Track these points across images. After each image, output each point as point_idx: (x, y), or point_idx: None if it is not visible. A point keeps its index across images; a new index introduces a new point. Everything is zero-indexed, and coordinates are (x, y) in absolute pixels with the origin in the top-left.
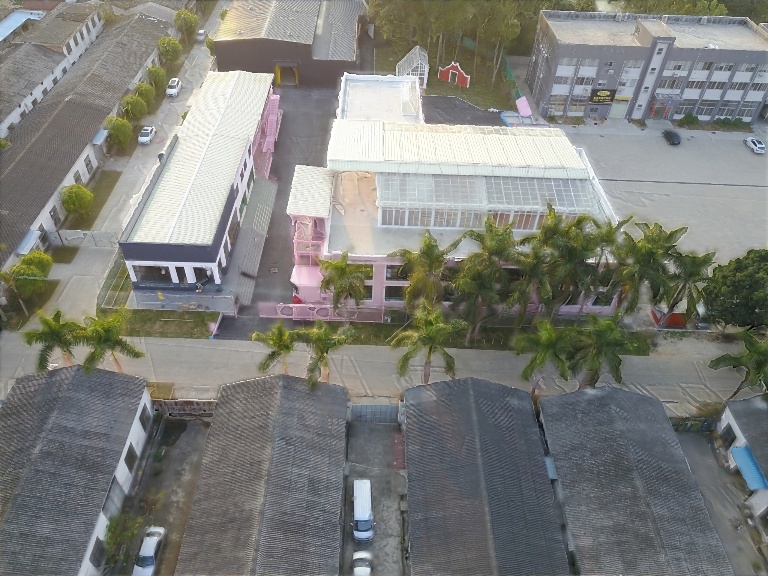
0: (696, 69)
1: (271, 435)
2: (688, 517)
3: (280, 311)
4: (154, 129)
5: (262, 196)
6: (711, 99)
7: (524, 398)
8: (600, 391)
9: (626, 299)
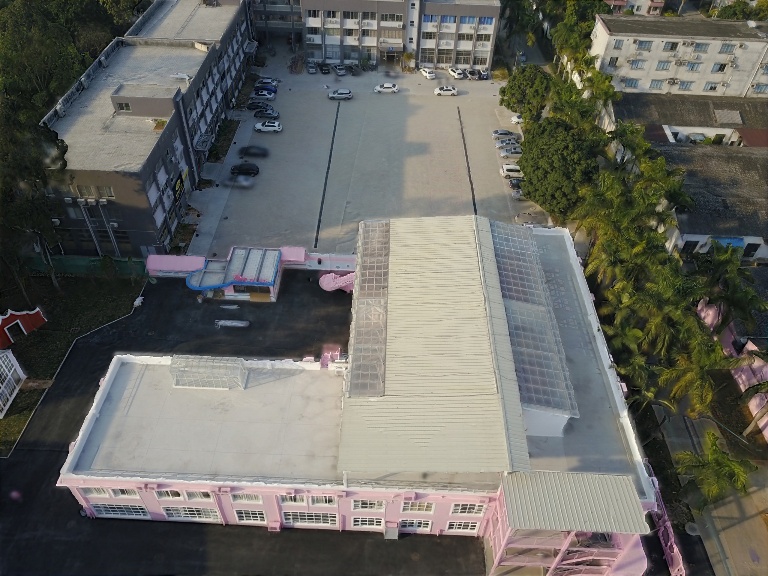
0: None
1: None
2: None
3: None
4: None
5: None
6: None
7: (759, 341)
8: None
9: None
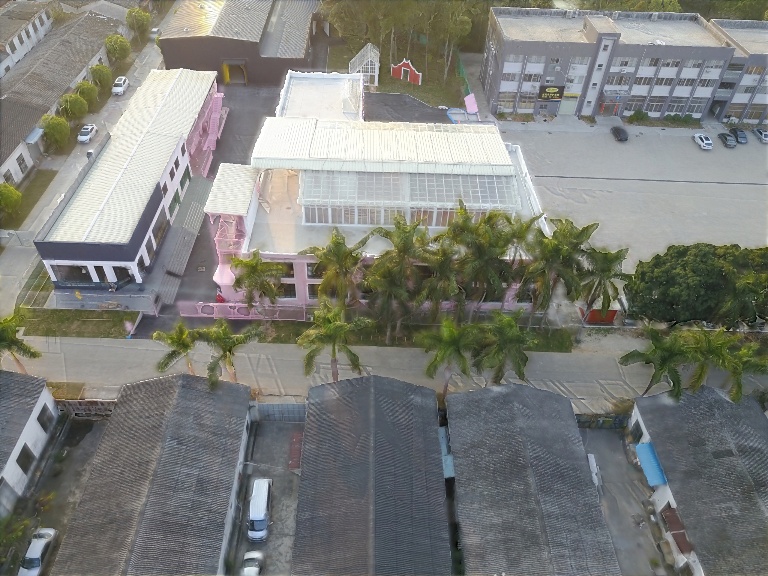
0: (643, 65)
1: (163, 435)
2: (580, 514)
3: (202, 310)
4: (95, 128)
5: (197, 194)
6: (660, 95)
7: (428, 396)
8: (505, 388)
9: (556, 296)
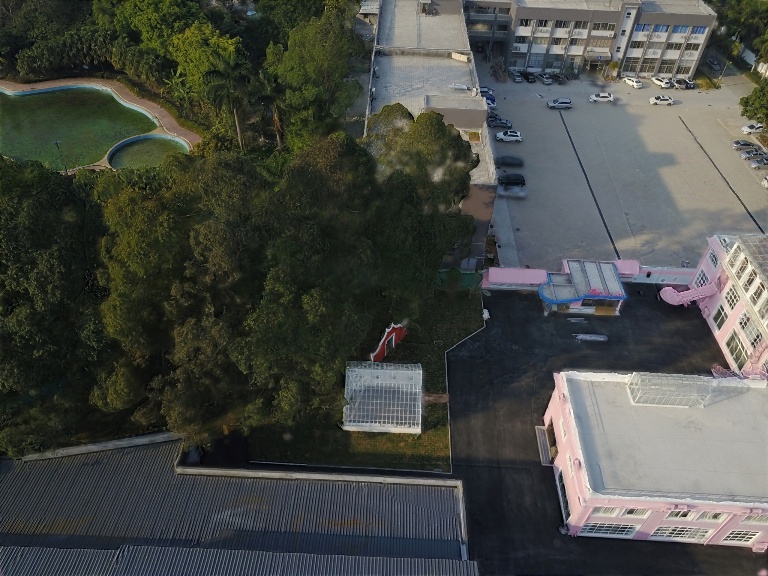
0: None
1: None
2: None
3: None
4: None
5: None
6: None
7: None
8: None
9: None
